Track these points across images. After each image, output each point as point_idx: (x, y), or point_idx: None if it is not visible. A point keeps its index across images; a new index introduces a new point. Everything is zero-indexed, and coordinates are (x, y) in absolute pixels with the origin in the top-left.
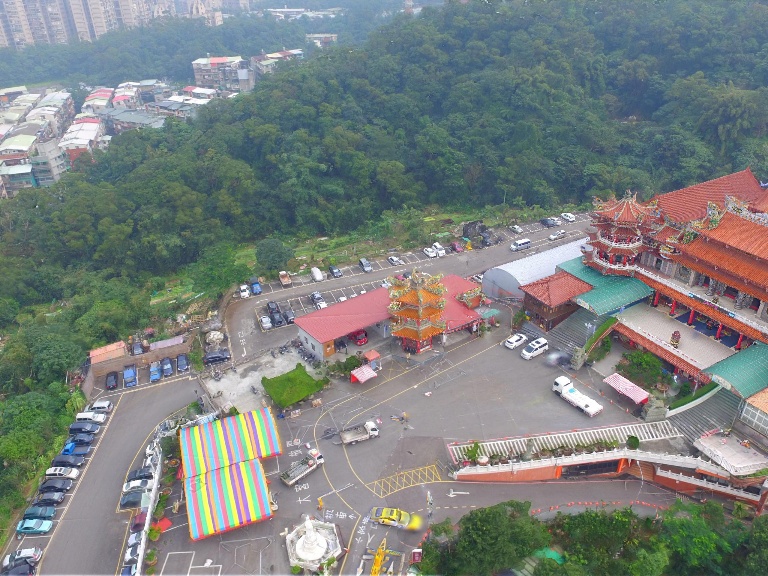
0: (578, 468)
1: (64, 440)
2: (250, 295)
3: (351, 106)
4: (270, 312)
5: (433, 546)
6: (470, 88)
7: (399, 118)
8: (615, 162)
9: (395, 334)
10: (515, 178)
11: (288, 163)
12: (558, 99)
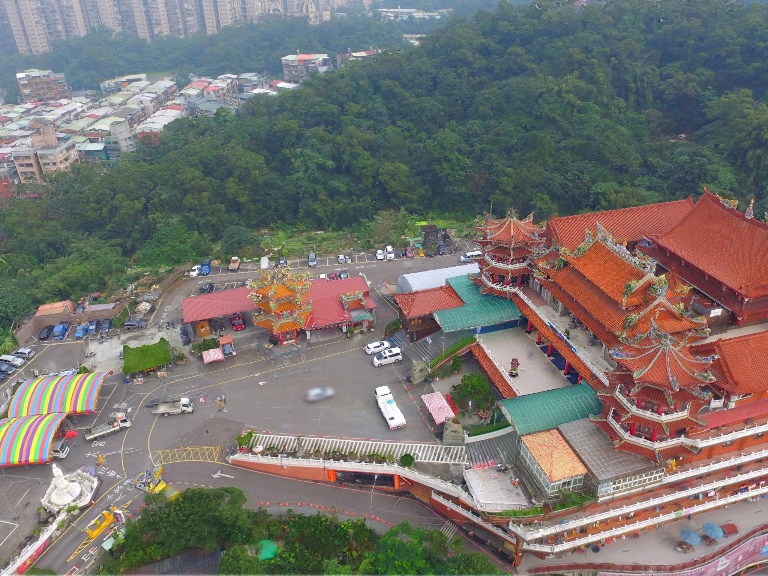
0: (353, 475)
1: None
2: (198, 275)
3: (375, 107)
4: (202, 292)
5: (151, 513)
6: (493, 95)
7: (423, 121)
8: (632, 182)
9: (257, 324)
10: (513, 190)
11: (300, 158)
12: (584, 111)
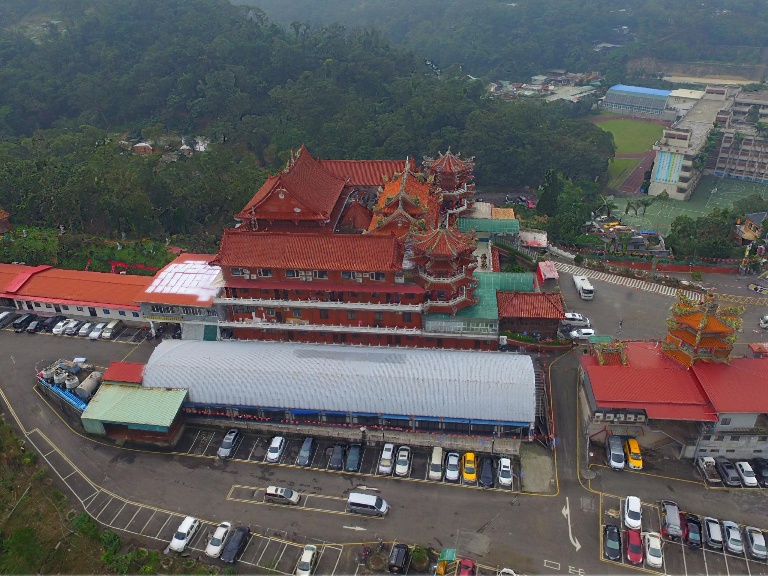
0: None
1: None
2: None
3: None
4: None
5: None
6: None
7: None
8: None
9: None
10: None
11: None
12: None
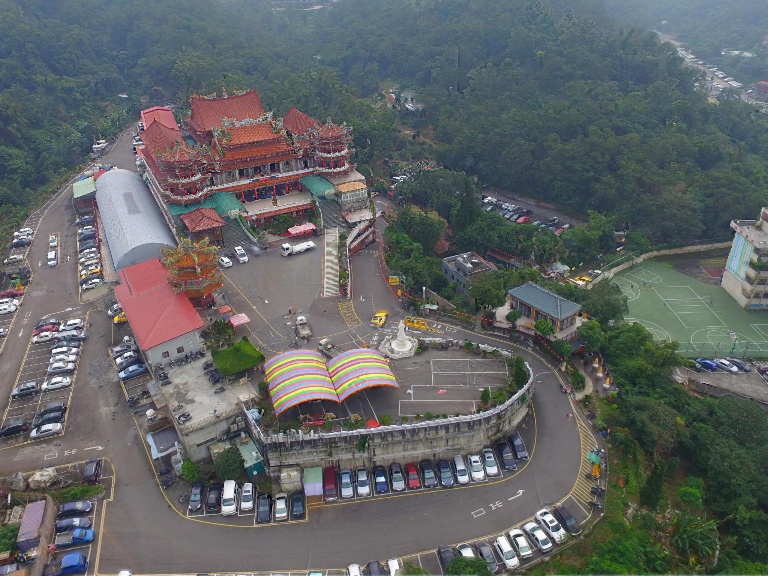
0: None
1: None
2: None
3: None
4: (25, 430)
5: None
6: None
7: None
8: None
9: None
10: None
11: None
12: None
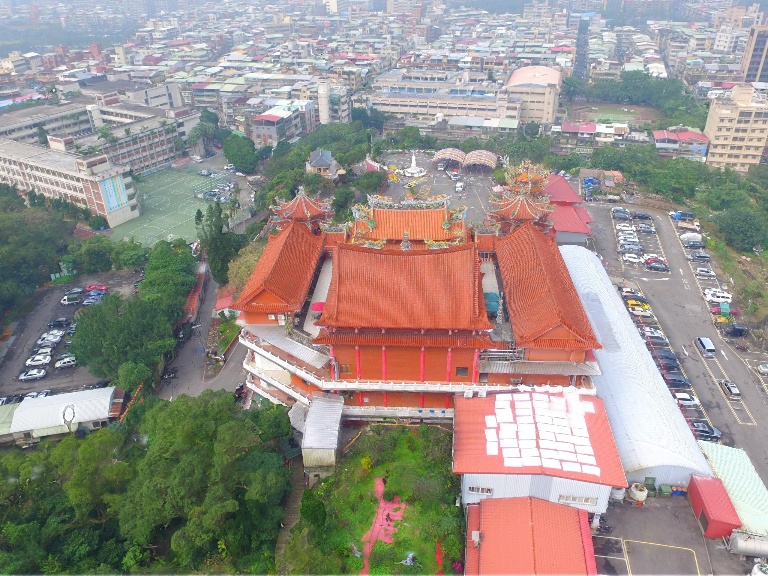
0: None
1: (551, 171)
2: None
3: None
4: None
5: None
6: None
7: None
8: None
9: None
10: None
11: None
12: None
